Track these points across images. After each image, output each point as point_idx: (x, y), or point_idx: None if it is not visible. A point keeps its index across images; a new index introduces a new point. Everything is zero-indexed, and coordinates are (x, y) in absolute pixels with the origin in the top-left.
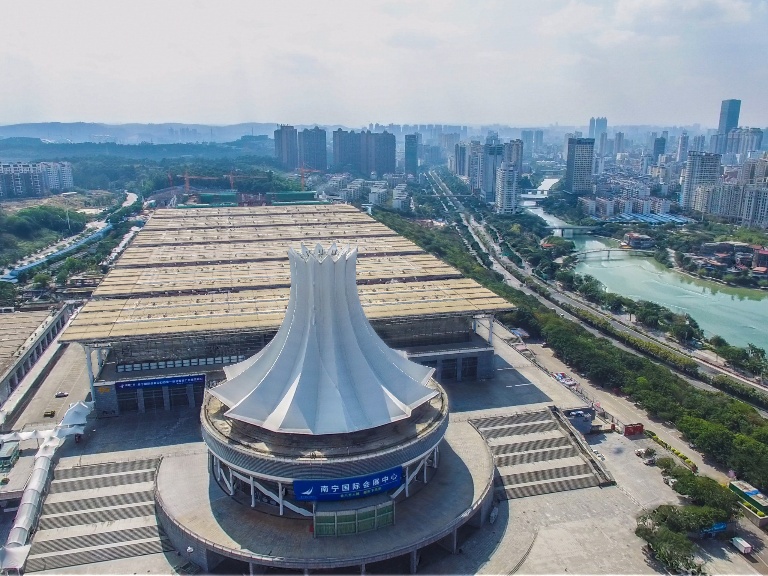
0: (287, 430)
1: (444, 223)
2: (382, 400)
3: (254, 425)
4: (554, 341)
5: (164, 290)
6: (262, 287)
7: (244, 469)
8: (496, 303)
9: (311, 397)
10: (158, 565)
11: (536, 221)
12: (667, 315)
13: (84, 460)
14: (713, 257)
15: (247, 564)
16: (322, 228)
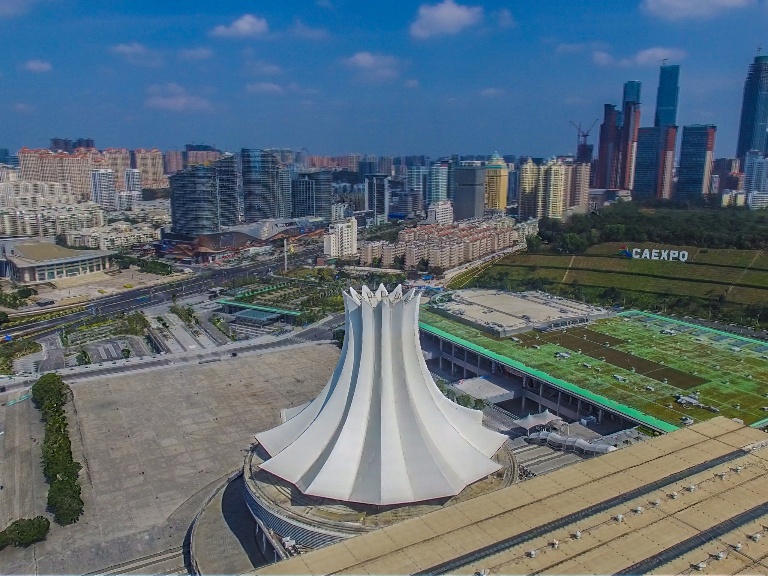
0: None
1: None
2: None
3: None
4: None
5: None
6: None
7: None
8: None
9: None
10: None
11: None
12: None
13: None
14: None
15: None
16: None
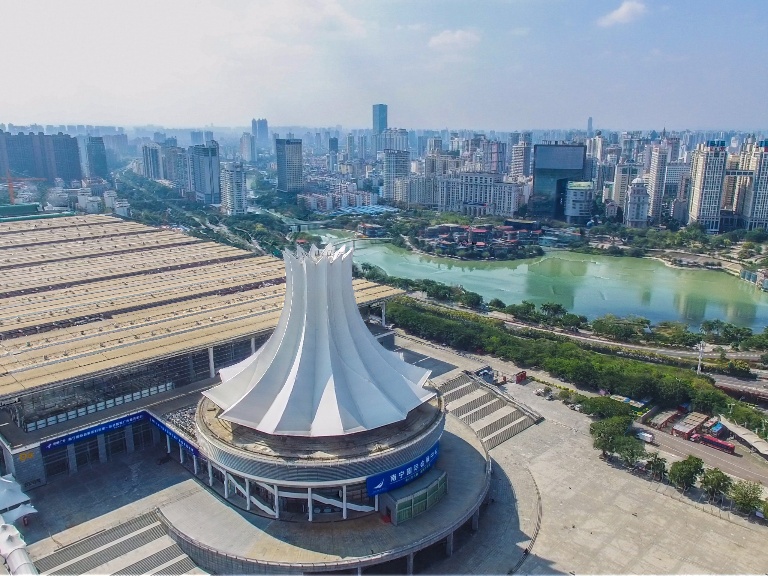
0: (350, 431)
1: (181, 228)
2: (405, 385)
3: (303, 437)
4: (406, 320)
5: (16, 328)
6: (134, 308)
7: (310, 482)
8: (386, 290)
9: (347, 396)
10: None
11: (274, 219)
12: (448, 288)
13: (61, 540)
14: (438, 238)
15: (355, 570)
16: (109, 241)
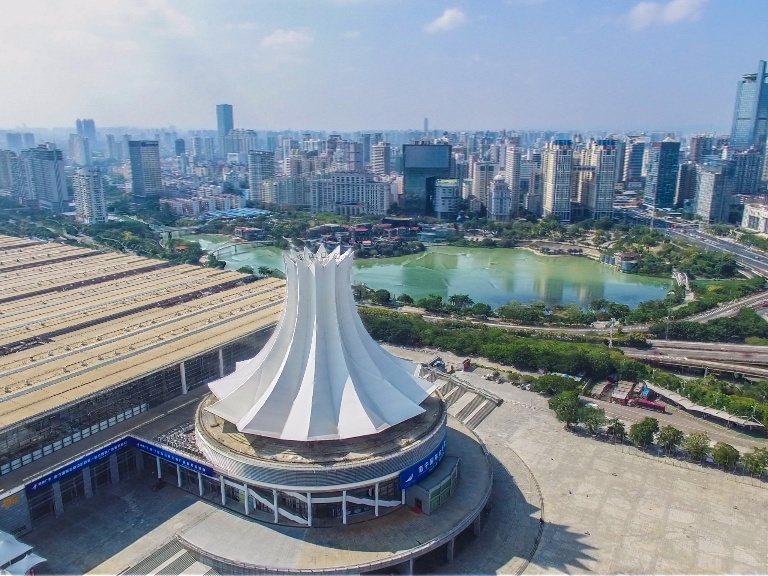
0: (380, 429)
1: None
2: (410, 380)
3: (334, 440)
4: None
5: None
6: (72, 328)
7: (348, 484)
8: None
9: (364, 396)
10: None
11: (142, 227)
12: None
13: None
14: (321, 239)
15: (408, 563)
16: None
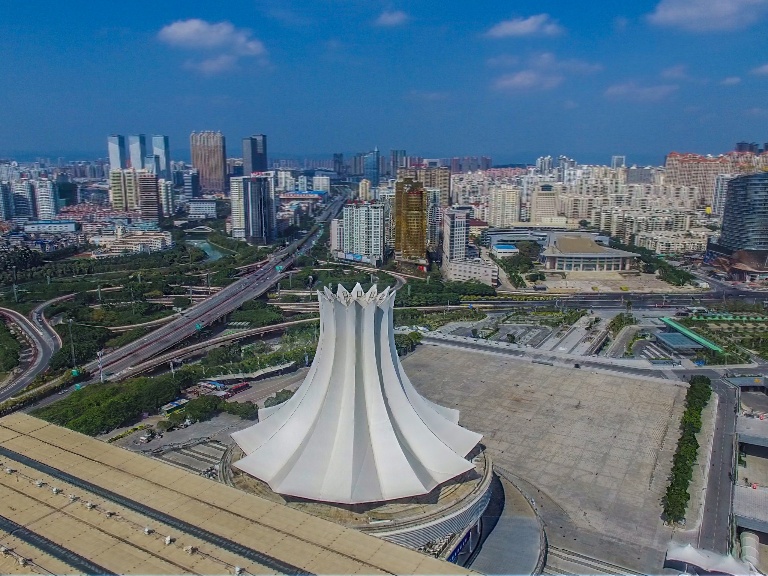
0: None
1: None
2: None
3: None
4: None
5: None
6: None
7: None
8: (3, 426)
9: None
10: (556, 537)
11: None
12: None
13: None
14: None
15: None
16: None
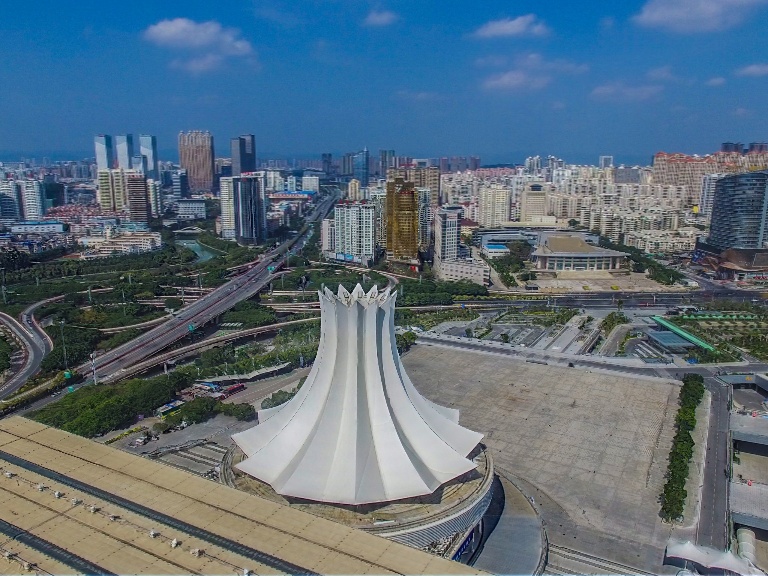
0: None
1: None
2: None
3: None
4: None
5: None
6: None
7: None
8: (1, 429)
9: None
10: (556, 535)
11: None
12: None
13: None
14: None
15: None
16: None
